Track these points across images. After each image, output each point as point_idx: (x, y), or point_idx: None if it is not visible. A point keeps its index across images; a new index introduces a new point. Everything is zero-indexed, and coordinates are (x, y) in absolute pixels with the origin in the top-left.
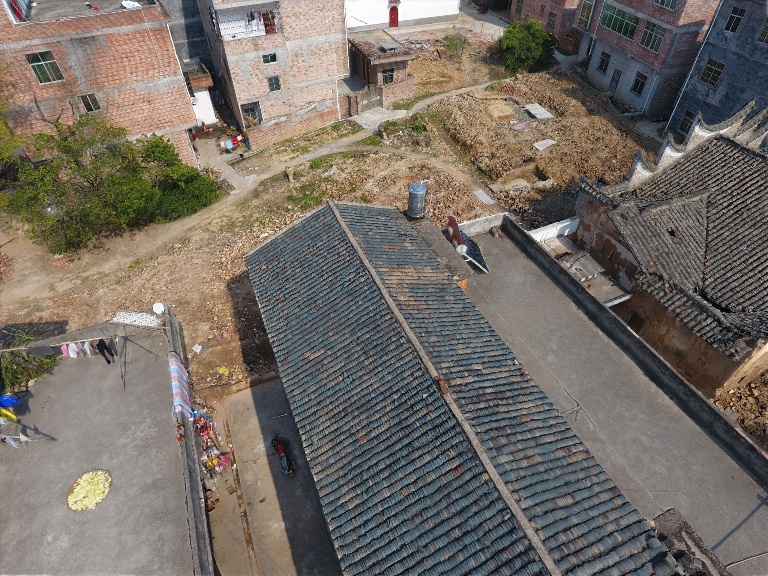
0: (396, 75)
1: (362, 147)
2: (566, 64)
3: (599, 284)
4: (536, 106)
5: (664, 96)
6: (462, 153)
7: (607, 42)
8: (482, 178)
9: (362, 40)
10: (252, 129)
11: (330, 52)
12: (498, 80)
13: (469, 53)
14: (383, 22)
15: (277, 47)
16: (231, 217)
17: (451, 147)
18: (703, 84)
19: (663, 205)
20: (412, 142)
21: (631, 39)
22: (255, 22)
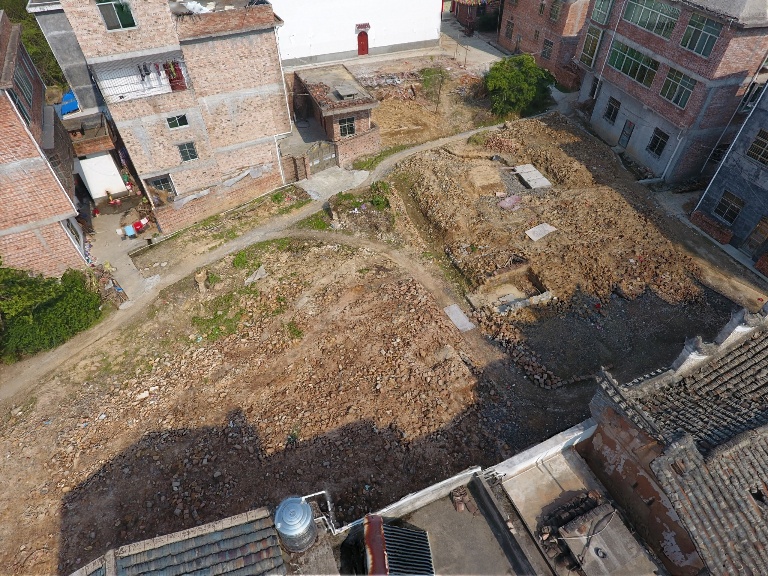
0: (357, 125)
1: (305, 231)
2: (565, 105)
3: (634, 570)
4: (529, 168)
5: (690, 160)
6: (434, 239)
7: (616, 87)
8: (458, 281)
9: (316, 80)
10: (161, 209)
11: (264, 107)
12: (483, 128)
13: (449, 90)
14: (350, 49)
15: (186, 107)
16: (107, 355)
17: (421, 228)
18: (750, 161)
19: (740, 441)
20: (369, 225)
21: (648, 87)
22: (154, 76)
